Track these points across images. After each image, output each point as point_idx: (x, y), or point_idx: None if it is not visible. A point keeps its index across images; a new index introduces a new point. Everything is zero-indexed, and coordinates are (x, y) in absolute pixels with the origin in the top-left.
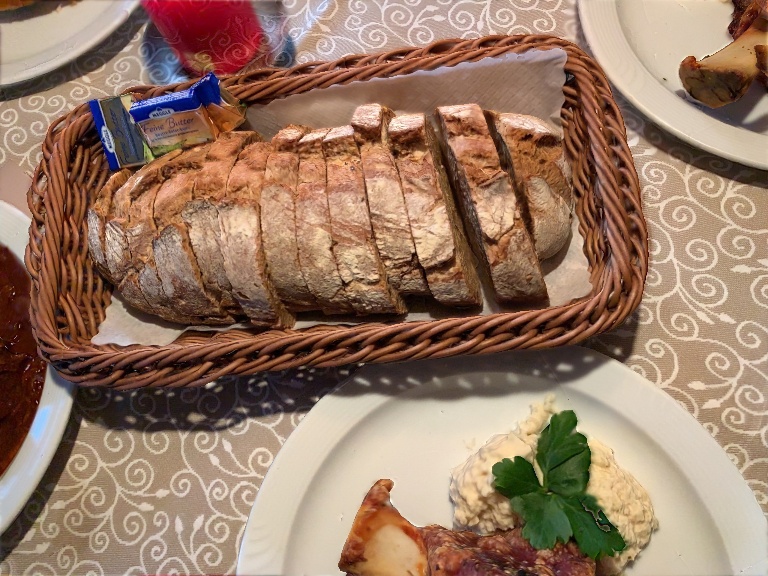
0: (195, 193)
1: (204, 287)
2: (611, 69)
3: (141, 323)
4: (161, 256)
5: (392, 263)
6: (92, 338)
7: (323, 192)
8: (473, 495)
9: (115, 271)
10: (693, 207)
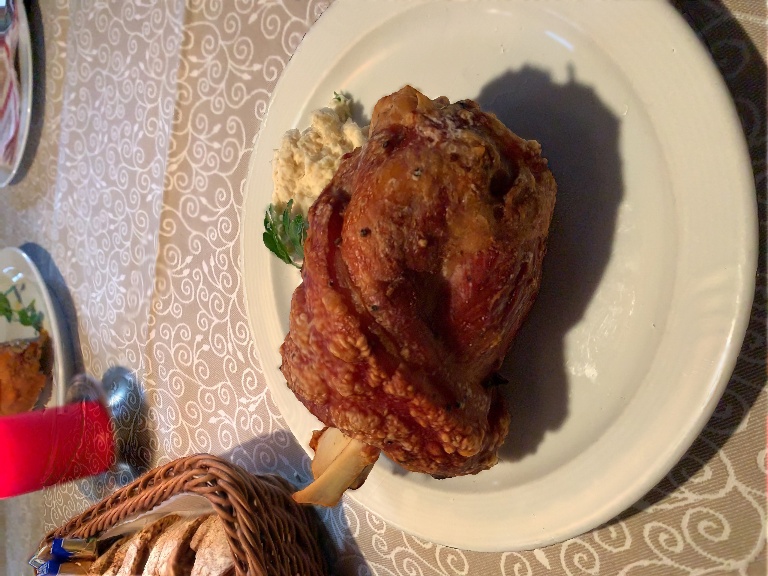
0: None
1: None
2: (290, 425)
3: None
4: None
5: None
6: None
7: None
8: None
9: None
10: (415, 560)
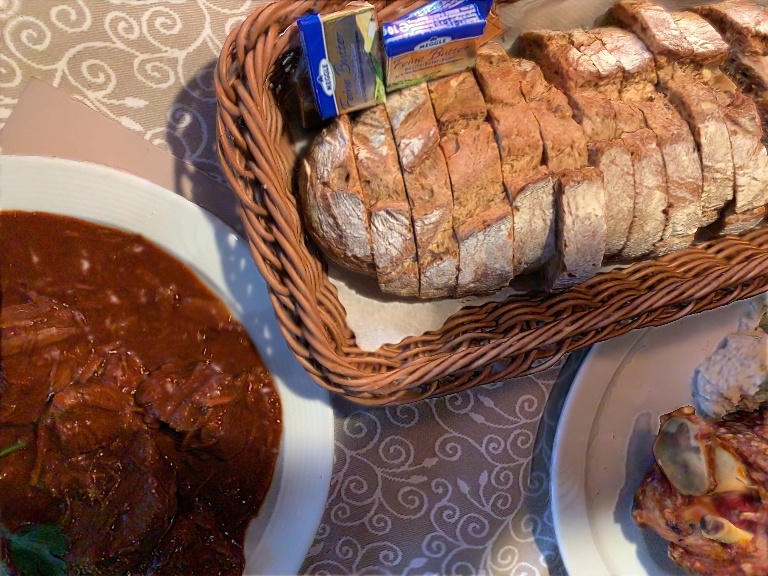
0: (504, 160)
1: (513, 269)
2: None
3: (383, 305)
4: (472, 246)
5: (702, 211)
6: (358, 344)
7: (656, 146)
8: (736, 395)
9: (387, 265)
10: None
